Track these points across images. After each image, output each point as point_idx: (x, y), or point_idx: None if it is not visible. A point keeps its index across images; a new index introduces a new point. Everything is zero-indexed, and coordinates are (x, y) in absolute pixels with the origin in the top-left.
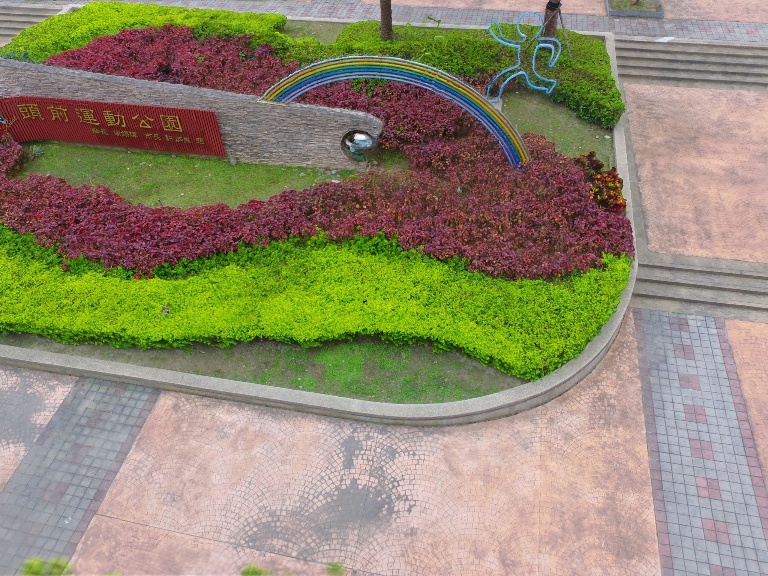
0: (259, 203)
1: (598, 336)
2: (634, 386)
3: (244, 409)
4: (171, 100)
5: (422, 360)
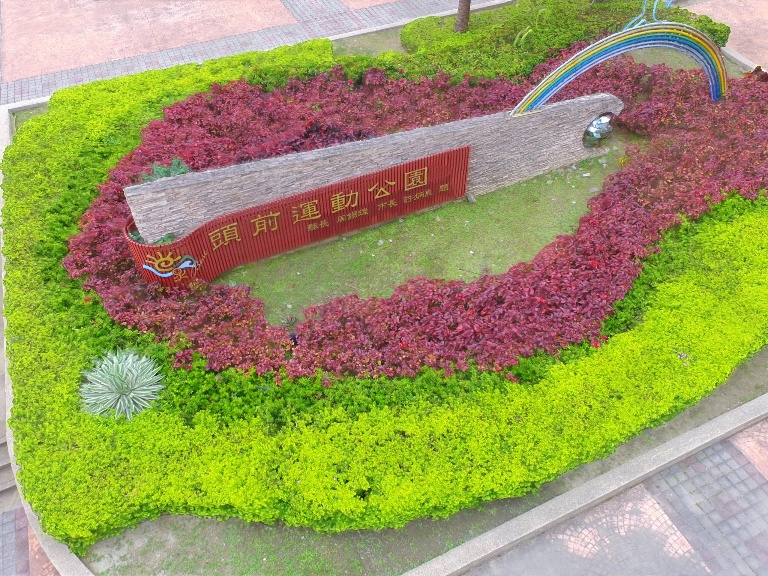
0: (593, 218)
1: None
2: None
3: None
4: (416, 150)
5: None
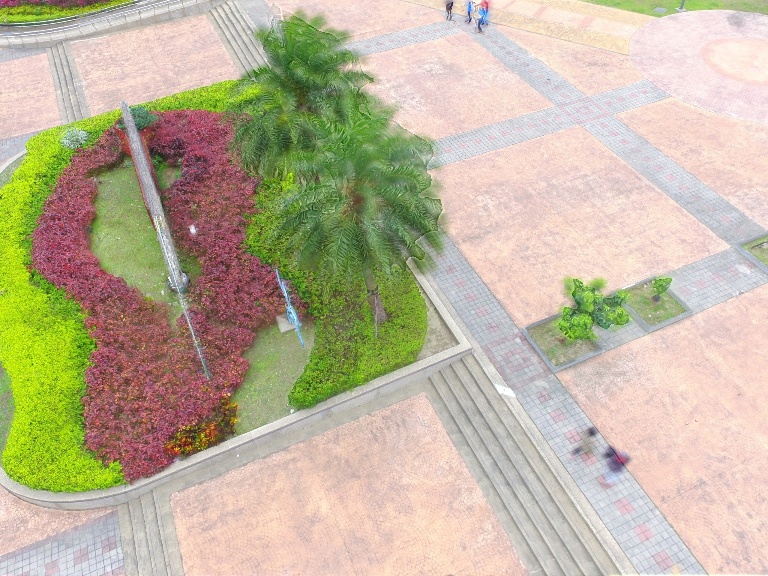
0: (102, 274)
1: (53, 493)
2: (39, 536)
3: None
4: None
5: None
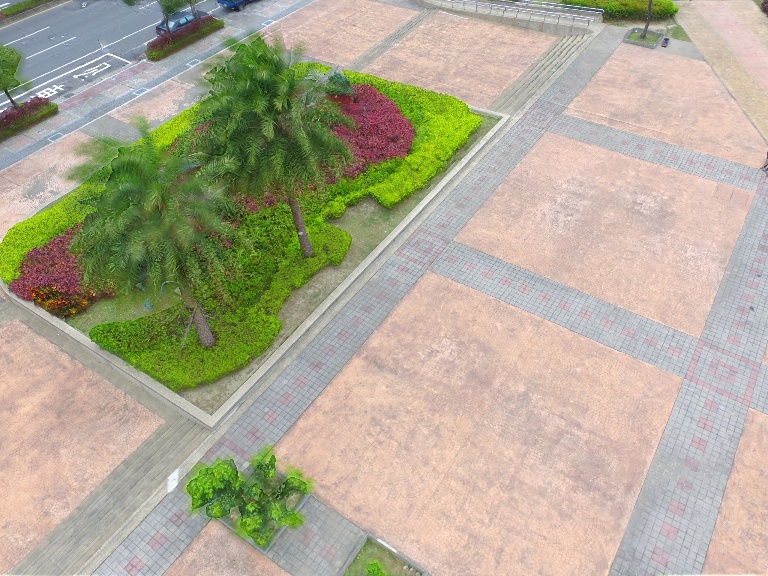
0: None
1: None
2: None
3: None
4: None
5: None
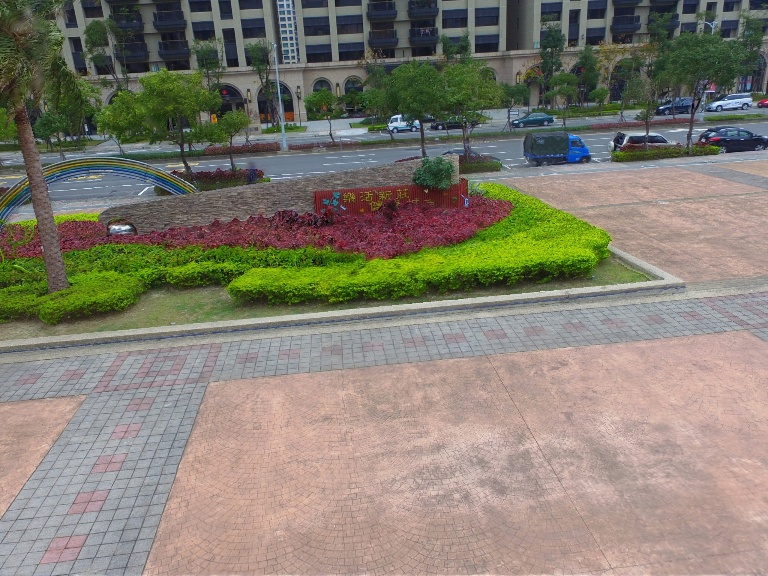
0: None
1: None
2: None
3: None
4: None
5: None
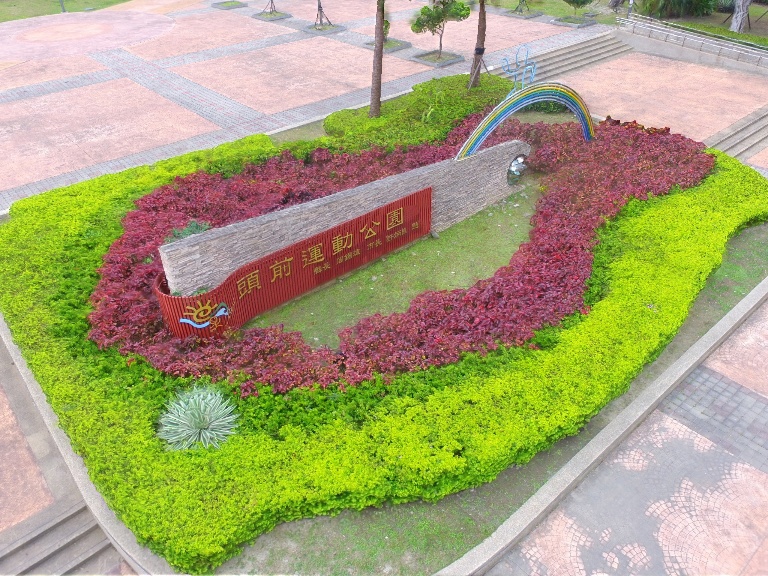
0: None
1: None
2: None
3: (744, 331)
4: (392, 194)
5: (740, 244)
